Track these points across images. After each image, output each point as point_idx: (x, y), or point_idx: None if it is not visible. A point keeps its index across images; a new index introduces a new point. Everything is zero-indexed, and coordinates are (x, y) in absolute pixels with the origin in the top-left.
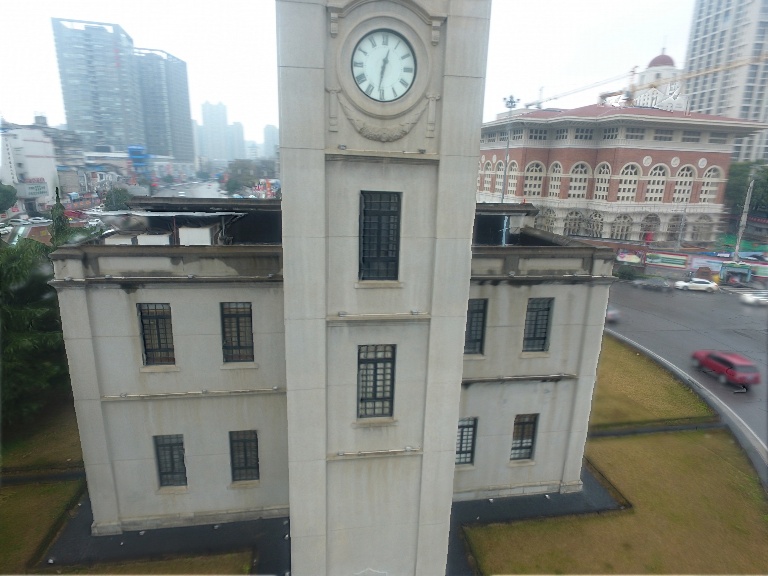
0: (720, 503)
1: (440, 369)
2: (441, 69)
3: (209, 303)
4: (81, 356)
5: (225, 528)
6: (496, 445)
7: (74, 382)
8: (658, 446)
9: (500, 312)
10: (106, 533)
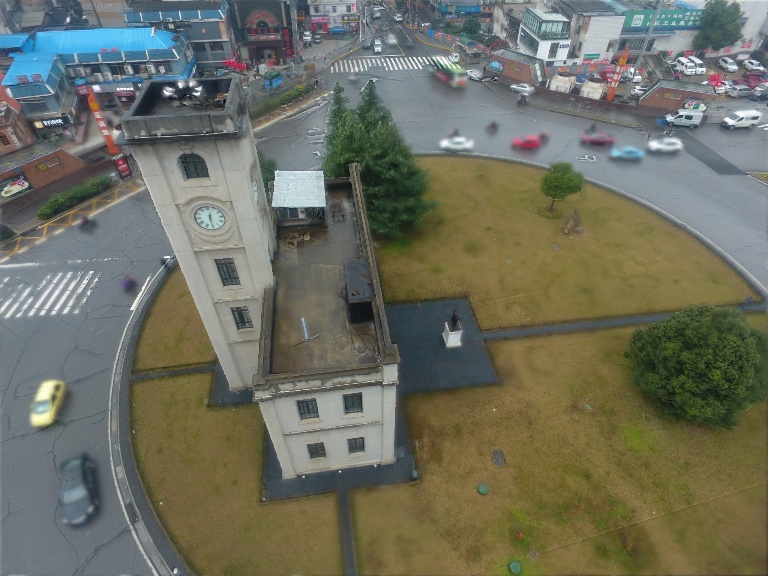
0: (251, 575)
1: None
2: None
3: None
4: None
5: None
6: None
7: None
8: (321, 570)
9: None
10: None
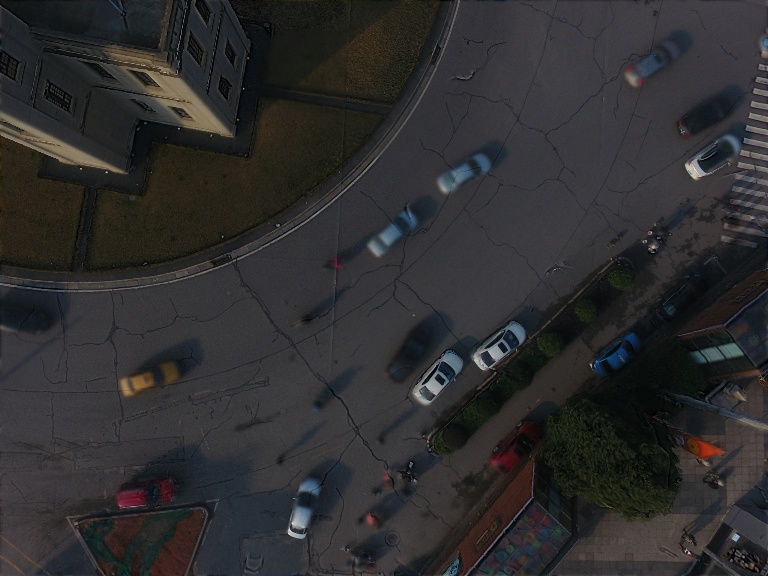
0: (299, 170)
1: (38, 133)
2: None
3: None
4: None
5: None
6: (166, 112)
7: None
8: (312, 120)
9: (112, 70)
10: None
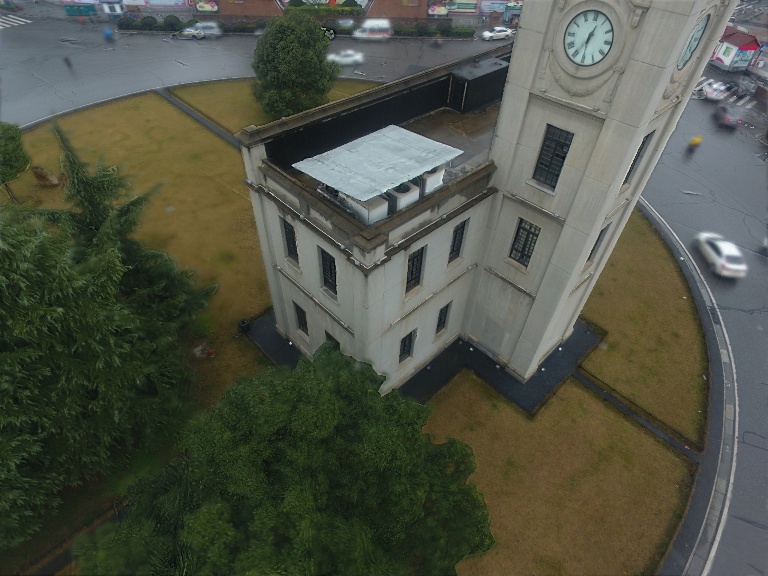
0: (628, 222)
1: None
2: (709, 34)
3: (449, 231)
4: (375, 314)
5: (433, 365)
6: None
7: (368, 334)
8: None
9: None
10: None
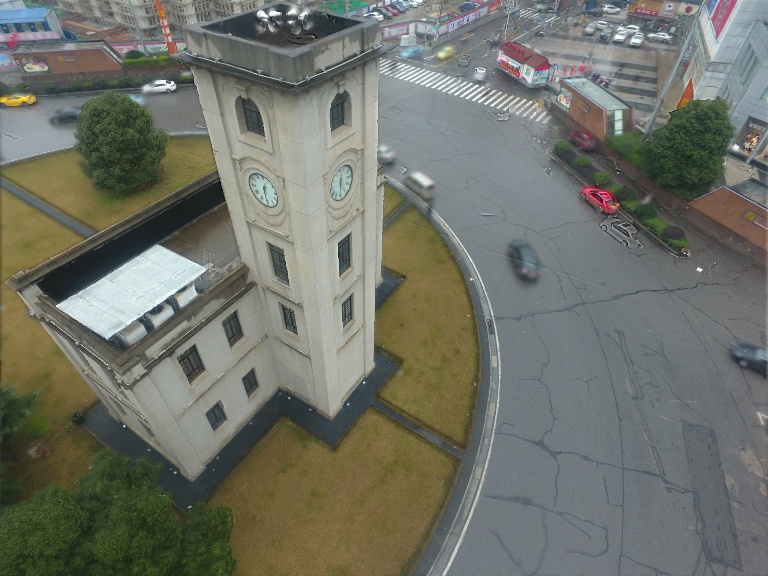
0: (431, 253)
1: None
2: (361, 169)
3: (216, 327)
4: (157, 410)
5: (255, 420)
6: None
7: (158, 425)
8: (395, 235)
9: None
10: (198, 475)
